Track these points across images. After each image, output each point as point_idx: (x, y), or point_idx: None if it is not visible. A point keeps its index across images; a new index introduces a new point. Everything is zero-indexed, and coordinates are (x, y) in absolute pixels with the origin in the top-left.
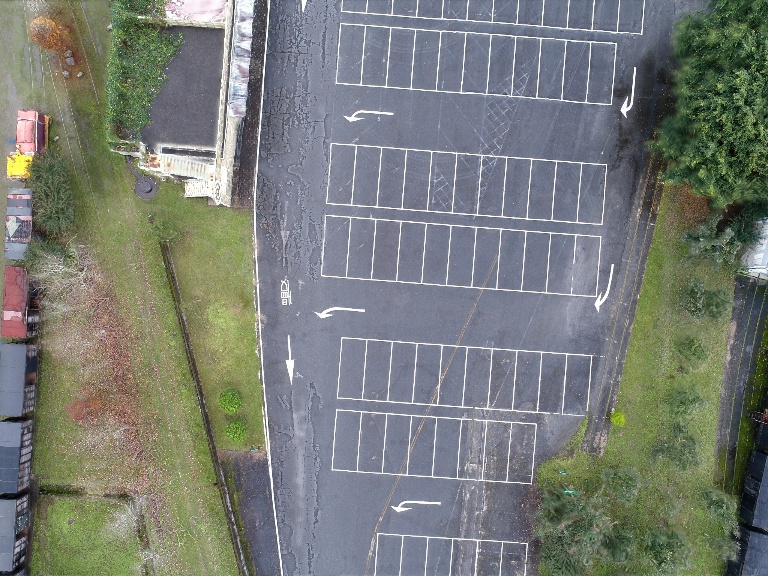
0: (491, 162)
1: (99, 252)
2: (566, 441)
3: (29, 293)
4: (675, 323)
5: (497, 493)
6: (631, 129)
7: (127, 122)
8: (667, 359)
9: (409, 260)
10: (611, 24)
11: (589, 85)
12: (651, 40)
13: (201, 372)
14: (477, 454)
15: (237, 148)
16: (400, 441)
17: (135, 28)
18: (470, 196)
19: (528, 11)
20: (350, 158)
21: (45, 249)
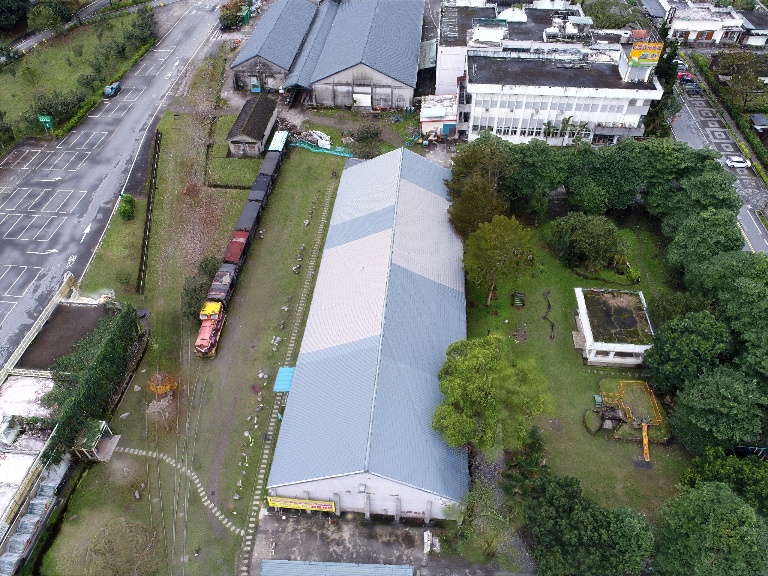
0: None
1: None
2: None
3: None
4: None
5: (0, 183)
6: None
7: None
8: None
9: None
10: None
11: None
12: None
13: None
14: (1, 197)
15: None
16: (41, 201)
17: None
18: None
19: None
20: None
21: None
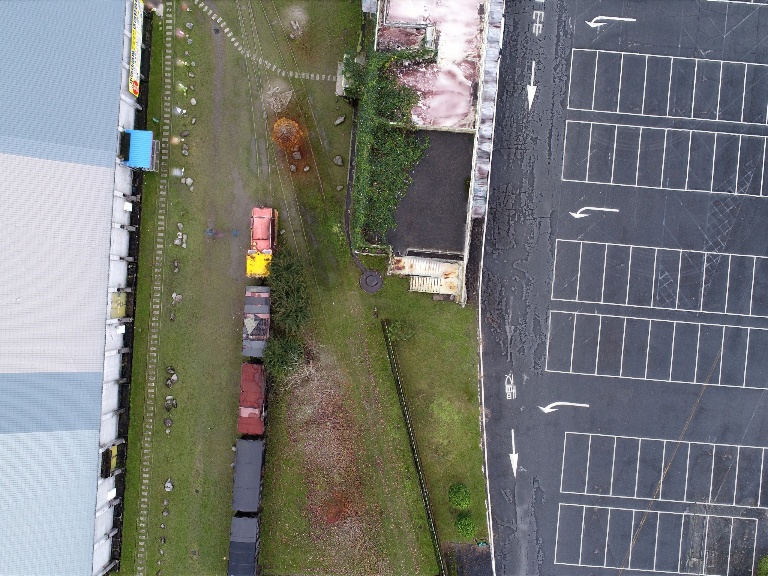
0: (715, 259)
1: None
2: None
3: (266, 390)
4: None
5: None
6: None
7: (373, 225)
8: None
9: (633, 356)
10: None
11: None
12: None
13: (425, 465)
14: (698, 548)
15: None
16: (622, 535)
17: (383, 132)
18: (694, 293)
19: (753, 109)
20: (575, 254)
21: (283, 347)
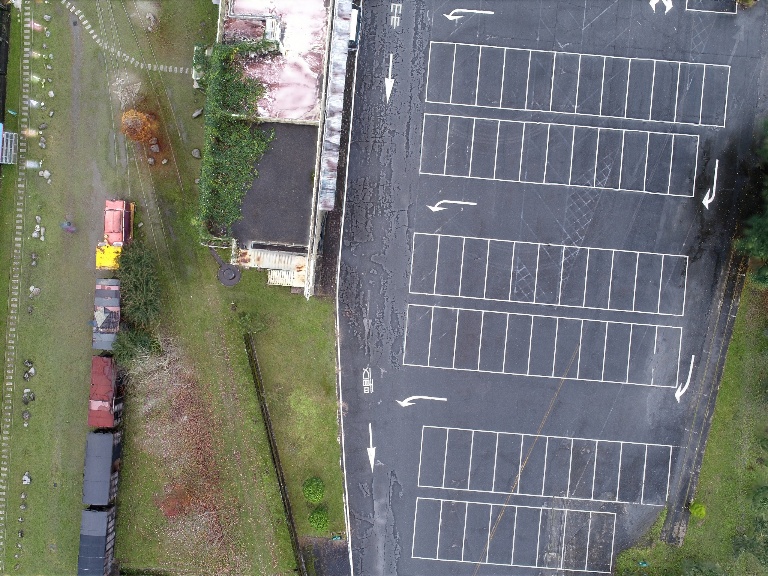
0: (573, 253)
1: (182, 338)
2: (645, 531)
3: (116, 383)
4: (755, 414)
5: None
6: (713, 221)
7: (218, 217)
8: (747, 450)
9: (491, 349)
10: (694, 116)
11: (671, 177)
12: (733, 132)
13: (283, 459)
14: (556, 543)
15: (320, 236)
16: (480, 529)
17: (227, 124)
18: (552, 286)
19: (611, 103)
20: (433, 248)
21: (133, 340)
